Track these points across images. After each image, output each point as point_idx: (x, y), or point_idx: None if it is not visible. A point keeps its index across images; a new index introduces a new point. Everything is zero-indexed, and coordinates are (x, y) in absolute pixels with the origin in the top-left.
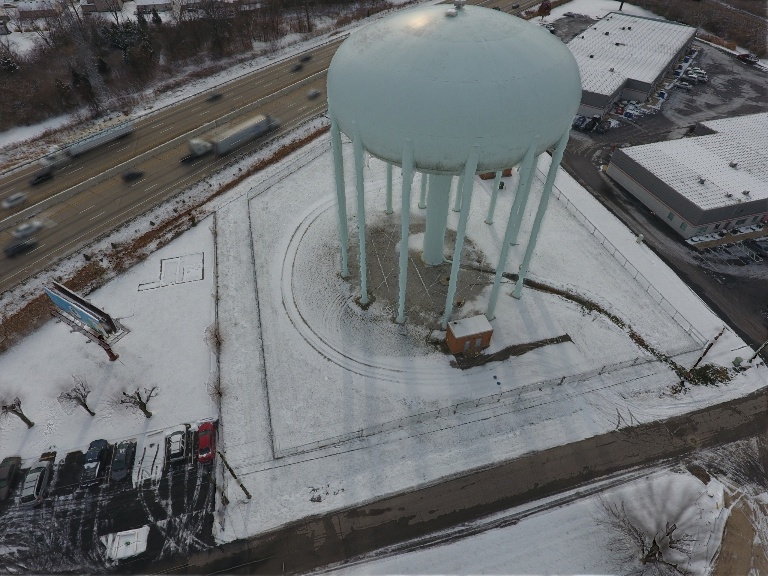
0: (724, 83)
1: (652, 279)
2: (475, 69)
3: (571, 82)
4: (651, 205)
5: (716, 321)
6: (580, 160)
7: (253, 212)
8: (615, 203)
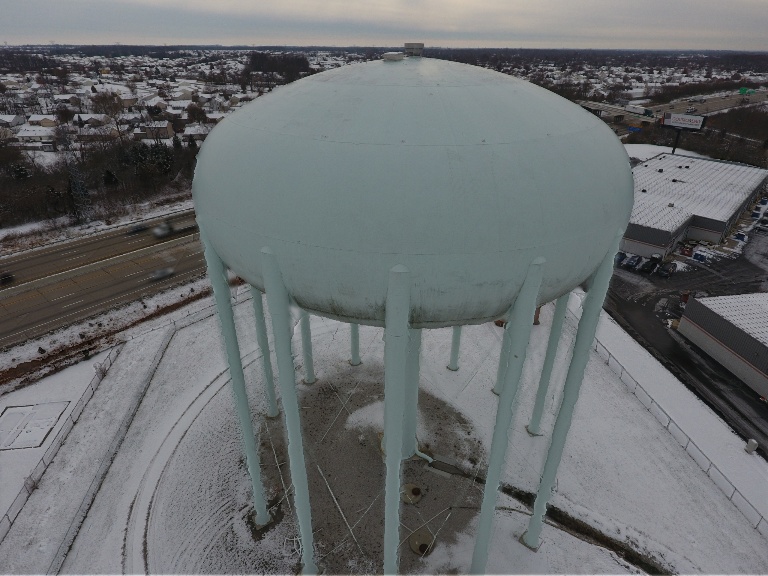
0: None
1: None
2: (405, 124)
3: (611, 167)
4: (758, 387)
5: None
6: (637, 310)
7: (172, 347)
8: (697, 378)
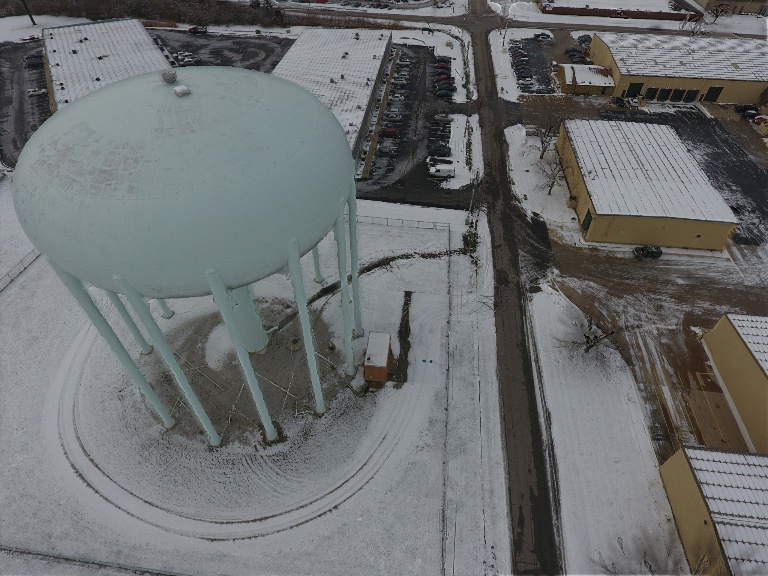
0: (211, 56)
1: (379, 215)
2: (289, 133)
3: None
4: None
5: (432, 210)
6: None
7: None
8: None
